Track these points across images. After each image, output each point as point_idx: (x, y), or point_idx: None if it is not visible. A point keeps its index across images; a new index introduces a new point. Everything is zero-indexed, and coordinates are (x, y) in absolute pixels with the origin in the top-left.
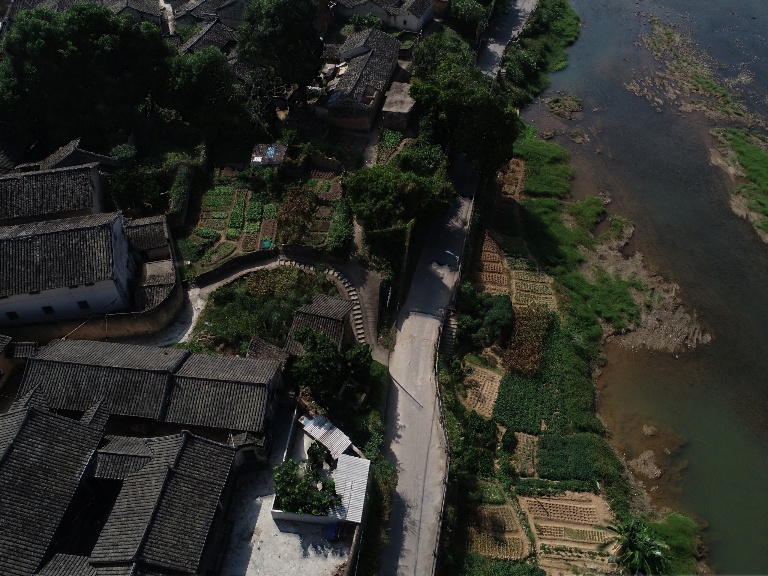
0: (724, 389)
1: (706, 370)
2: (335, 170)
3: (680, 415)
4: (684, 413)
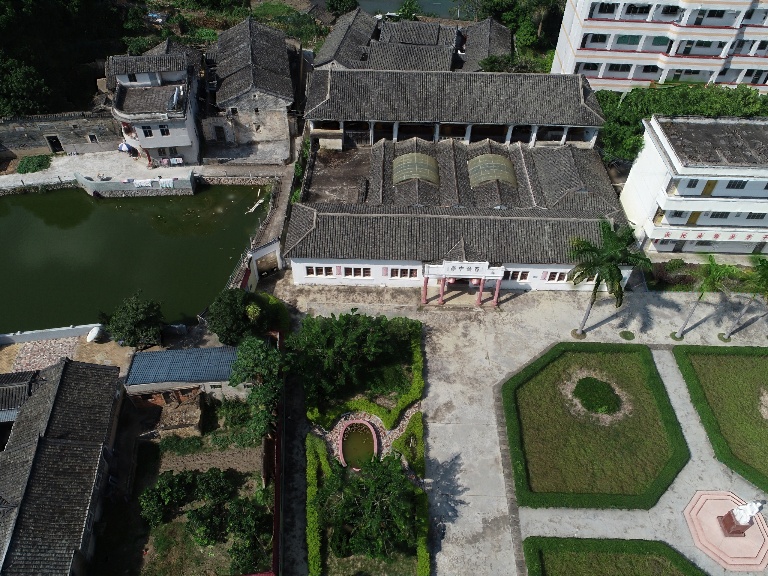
0: None
1: (322, 2)
2: None
3: None
4: None
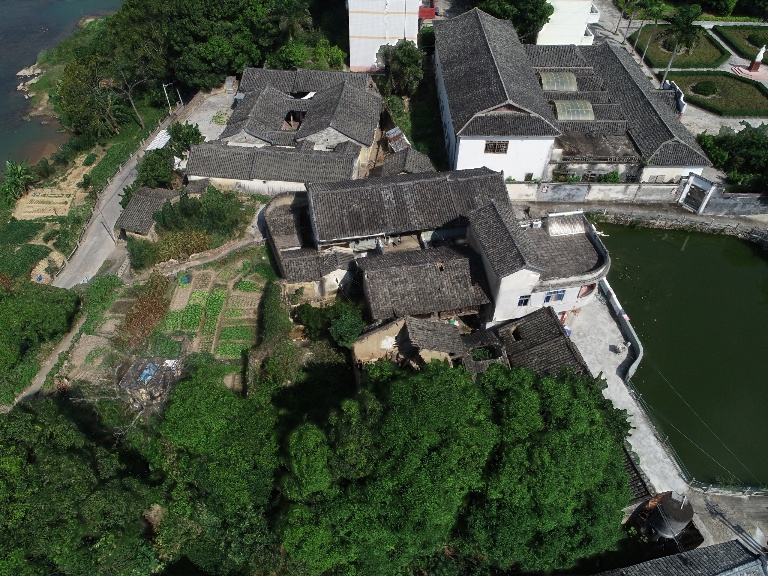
0: None
1: None
2: None
3: None
4: None
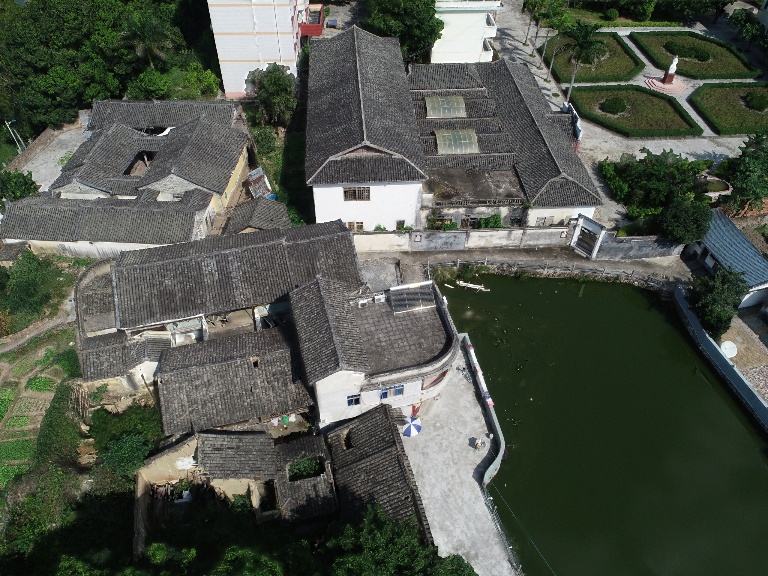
0: None
1: None
2: None
3: None
4: None
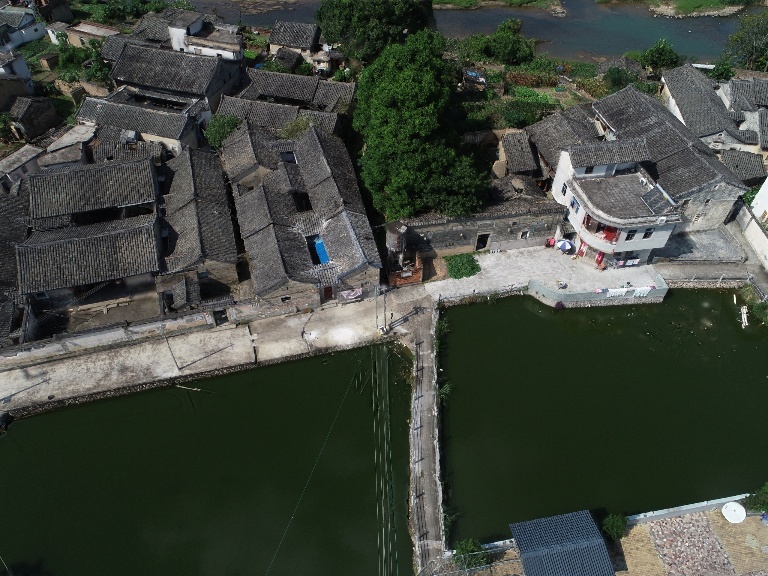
0: (549, 37)
1: None
2: (469, 66)
3: (568, 49)
4: (566, 48)
